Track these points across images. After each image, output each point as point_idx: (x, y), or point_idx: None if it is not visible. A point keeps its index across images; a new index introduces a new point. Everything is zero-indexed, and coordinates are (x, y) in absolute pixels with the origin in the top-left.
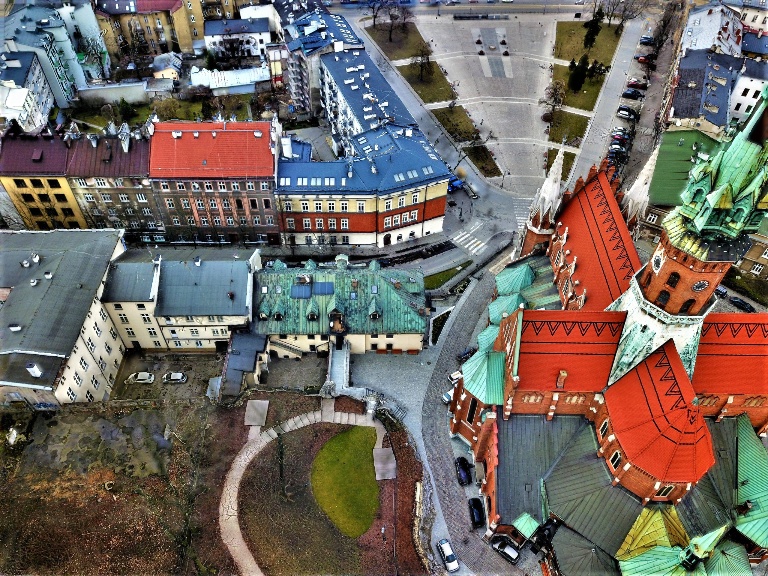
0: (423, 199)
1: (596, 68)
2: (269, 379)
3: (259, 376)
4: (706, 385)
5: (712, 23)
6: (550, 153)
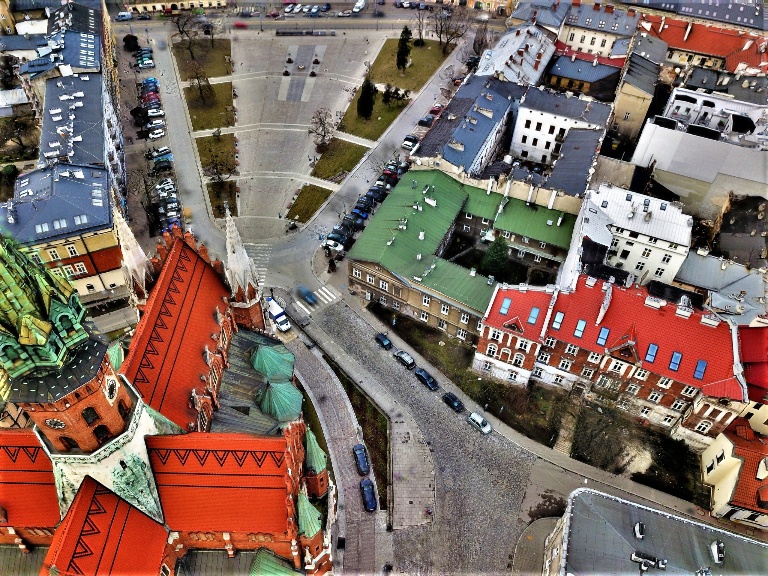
0: (84, 251)
1: (392, 93)
2: None
3: None
4: (183, 521)
5: (513, 46)
6: (304, 190)
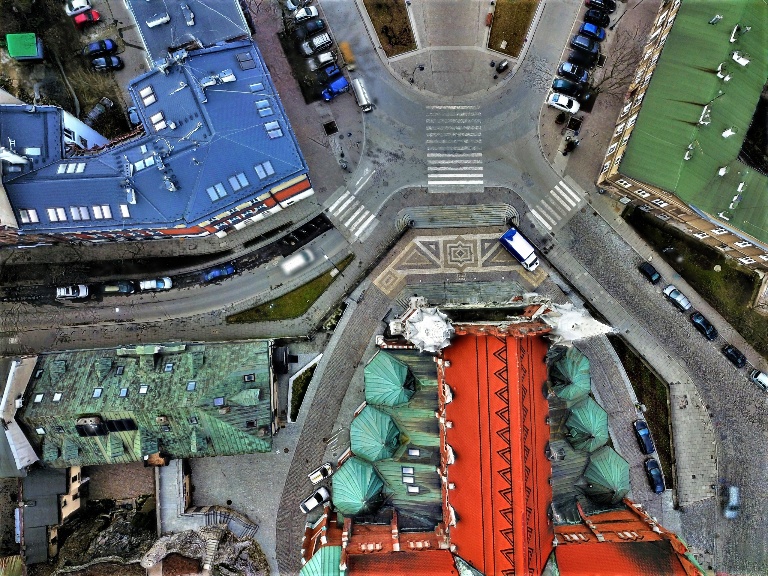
0: (267, 195)
1: None
2: (91, 488)
3: (77, 490)
4: None
5: None
6: None
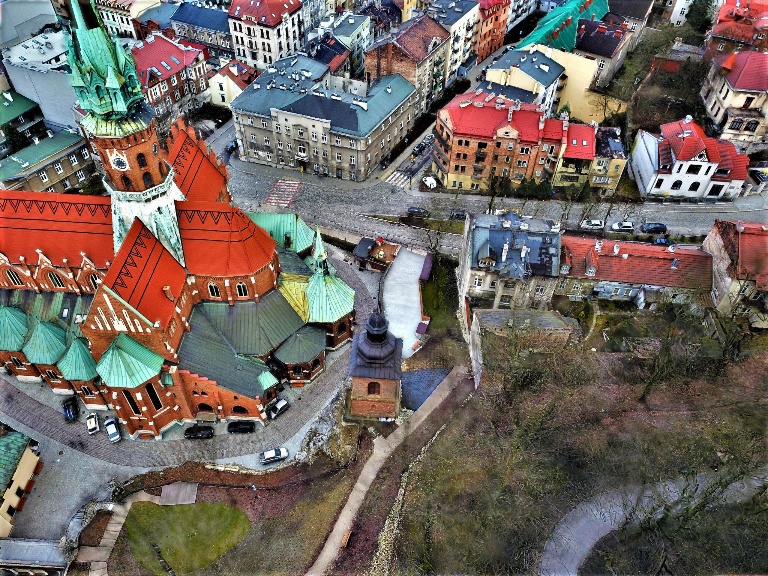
0: None
1: None
2: None
3: None
4: None
5: None
6: None
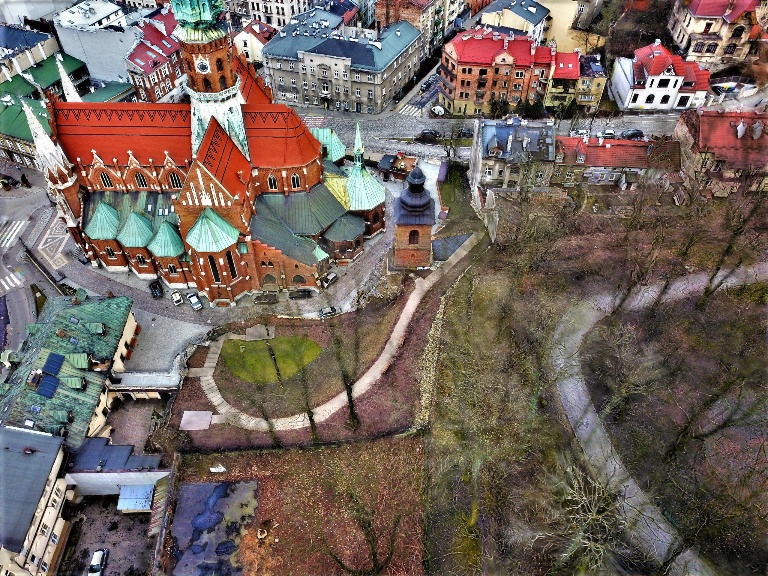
0: None
1: None
2: None
3: None
4: None
5: None
6: None
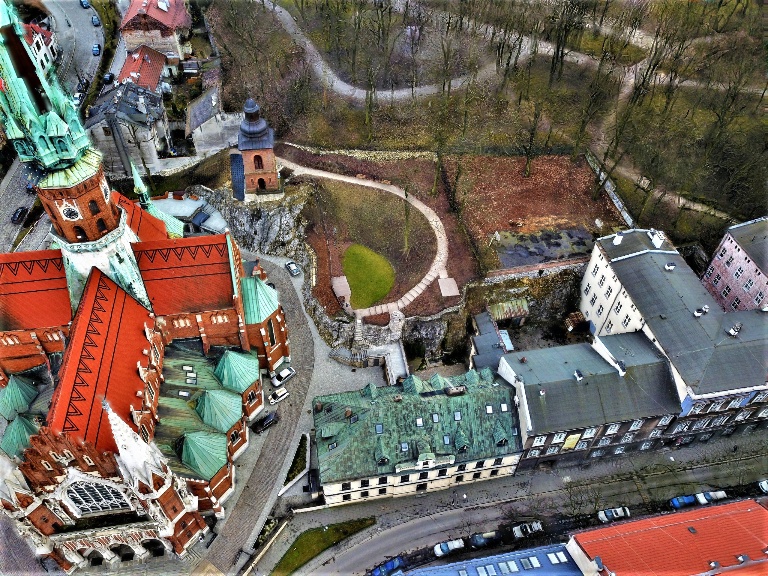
0: None
1: None
2: (464, 372)
3: None
4: None
5: None
6: None
